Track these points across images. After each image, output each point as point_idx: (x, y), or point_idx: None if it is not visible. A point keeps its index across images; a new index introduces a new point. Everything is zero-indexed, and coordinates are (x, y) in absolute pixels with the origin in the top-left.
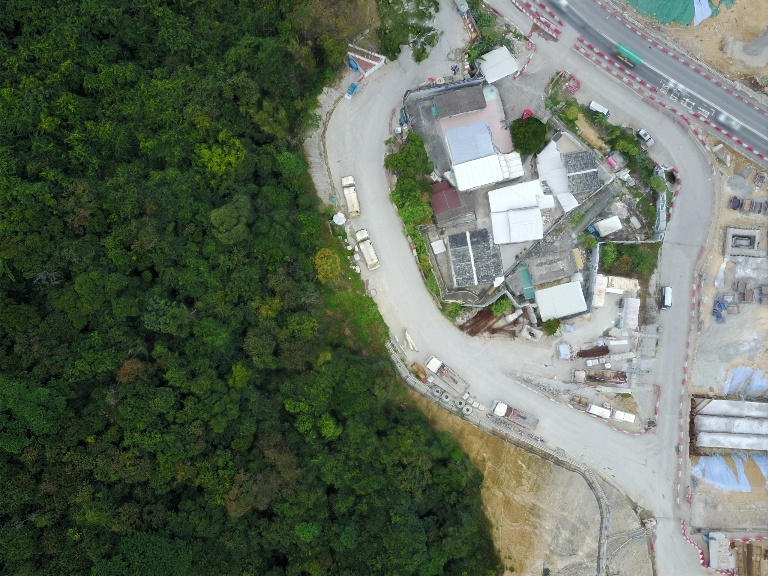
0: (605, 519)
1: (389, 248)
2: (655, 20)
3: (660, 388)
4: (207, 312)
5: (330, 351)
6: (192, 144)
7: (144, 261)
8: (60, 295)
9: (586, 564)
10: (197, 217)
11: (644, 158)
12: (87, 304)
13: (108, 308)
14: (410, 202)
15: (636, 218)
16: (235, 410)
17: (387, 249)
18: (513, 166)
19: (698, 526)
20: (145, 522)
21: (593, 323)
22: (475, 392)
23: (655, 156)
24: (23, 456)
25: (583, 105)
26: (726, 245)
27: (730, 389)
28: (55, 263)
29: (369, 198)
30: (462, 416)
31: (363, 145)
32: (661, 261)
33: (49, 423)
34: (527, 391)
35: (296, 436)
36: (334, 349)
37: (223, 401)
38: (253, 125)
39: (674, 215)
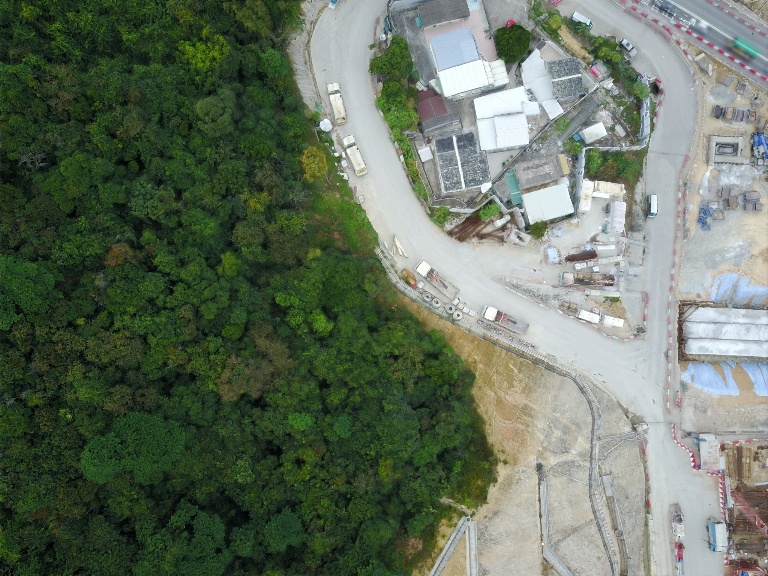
0: (597, 421)
1: (376, 155)
2: None
3: (648, 295)
4: (195, 204)
5: None
6: (176, 41)
7: (130, 150)
8: (46, 178)
9: (579, 463)
10: (183, 110)
11: (627, 67)
12: (73, 186)
13: (95, 193)
14: (396, 108)
15: (621, 126)
16: (225, 297)
17: (374, 156)
18: (498, 73)
19: (688, 430)
20: (137, 404)
21: (580, 229)
22: (465, 298)
23: (638, 67)
24: (12, 334)
25: (566, 17)
26: (710, 153)
27: (717, 297)
28: (40, 146)
29: (355, 106)
30: (453, 321)
31: (348, 54)
32: (646, 170)
33: (37, 298)
34: (517, 297)
35: (287, 330)
36: (323, 249)
37: (213, 287)
38: (237, 24)
39: (658, 125)
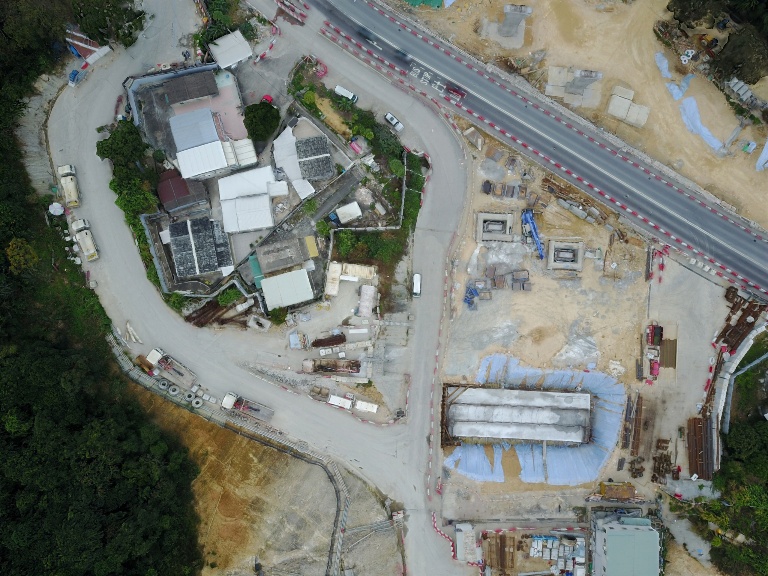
0: (342, 512)
1: (112, 238)
2: (405, 2)
3: (410, 377)
4: None
5: (24, 344)
6: None
7: None
8: None
9: (313, 558)
10: None
11: (390, 143)
12: None
13: None
14: (129, 191)
15: (380, 204)
16: None
17: (110, 239)
18: (245, 152)
19: (450, 517)
20: None
21: (332, 312)
22: (207, 384)
23: (406, 141)
24: None
25: (331, 90)
26: (477, 230)
27: (490, 377)
28: None
29: (92, 187)
30: (191, 409)
31: (87, 133)
32: (413, 248)
33: None
34: (264, 382)
35: None
36: (32, 342)
37: None
38: None
39: (427, 201)
